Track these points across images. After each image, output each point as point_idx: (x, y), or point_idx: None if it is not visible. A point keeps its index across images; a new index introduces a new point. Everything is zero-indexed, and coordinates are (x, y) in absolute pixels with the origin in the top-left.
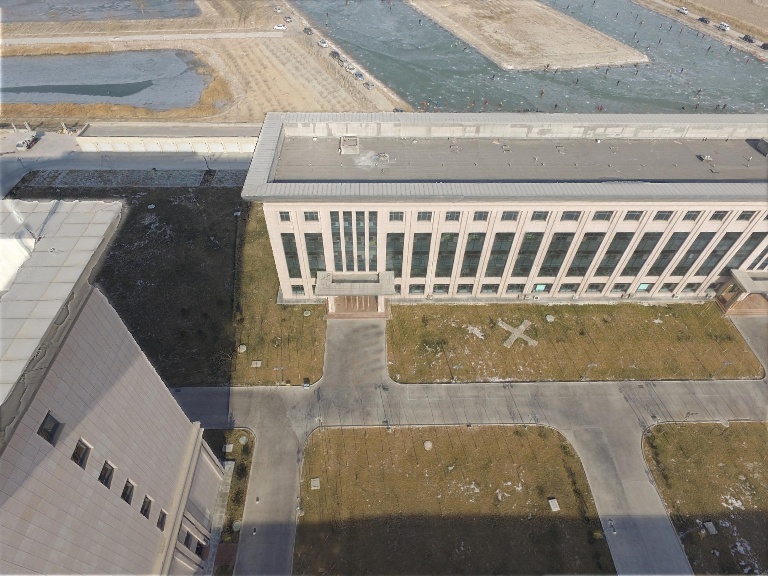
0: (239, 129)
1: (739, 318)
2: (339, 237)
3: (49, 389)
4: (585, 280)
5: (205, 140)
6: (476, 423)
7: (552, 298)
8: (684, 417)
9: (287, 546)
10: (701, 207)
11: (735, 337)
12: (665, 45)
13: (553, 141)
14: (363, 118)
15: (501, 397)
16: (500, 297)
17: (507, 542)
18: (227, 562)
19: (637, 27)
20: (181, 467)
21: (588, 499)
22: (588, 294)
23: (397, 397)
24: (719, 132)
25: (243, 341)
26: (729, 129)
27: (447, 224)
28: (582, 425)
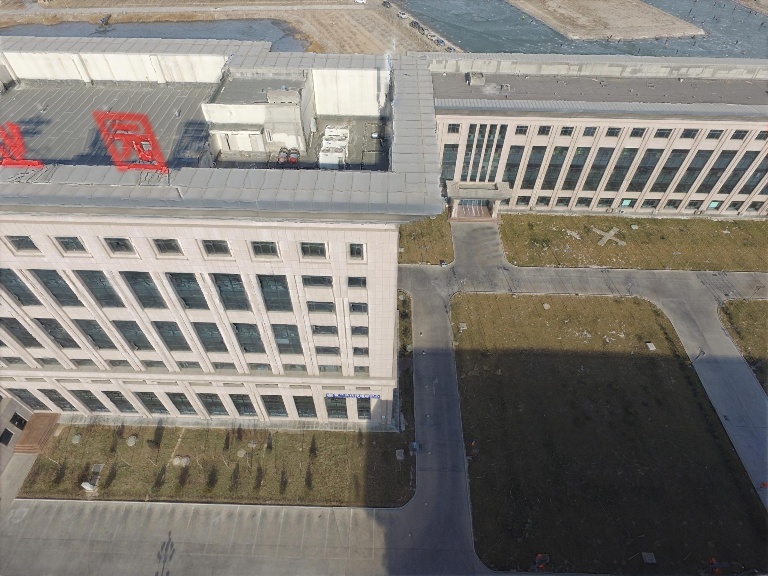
0: None
1: None
2: (471, 148)
3: None
4: (665, 196)
5: None
6: (583, 293)
7: (635, 212)
8: None
9: (450, 362)
10: None
11: None
12: (720, 20)
13: (642, 79)
14: (486, 57)
15: (600, 278)
16: (591, 210)
17: (616, 367)
18: None
19: (692, 5)
20: None
21: (677, 343)
22: (666, 210)
23: (517, 275)
24: None
25: None
26: None
27: (561, 138)
28: (668, 298)
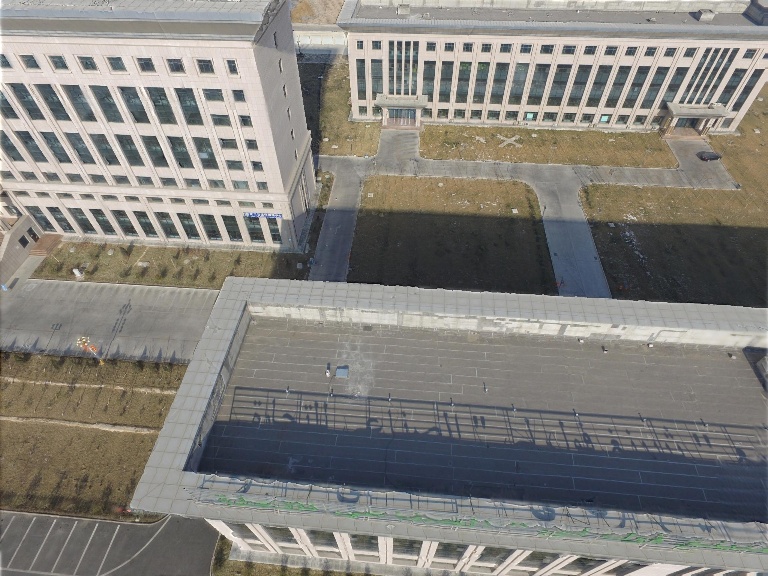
0: (322, 28)
1: (672, 141)
2: (393, 64)
3: (276, 23)
4: (561, 109)
5: (298, 33)
6: (473, 177)
7: (538, 125)
8: (613, 182)
9: None
10: (636, 43)
11: (665, 149)
12: None
13: (545, 11)
14: None
15: (492, 168)
16: (501, 123)
17: (483, 223)
18: (320, 218)
19: None
20: (303, 143)
21: (537, 210)
22: (564, 123)
23: (424, 164)
24: (668, 6)
25: (326, 137)
26: (675, 3)
27: (464, 54)
28: (542, 182)
